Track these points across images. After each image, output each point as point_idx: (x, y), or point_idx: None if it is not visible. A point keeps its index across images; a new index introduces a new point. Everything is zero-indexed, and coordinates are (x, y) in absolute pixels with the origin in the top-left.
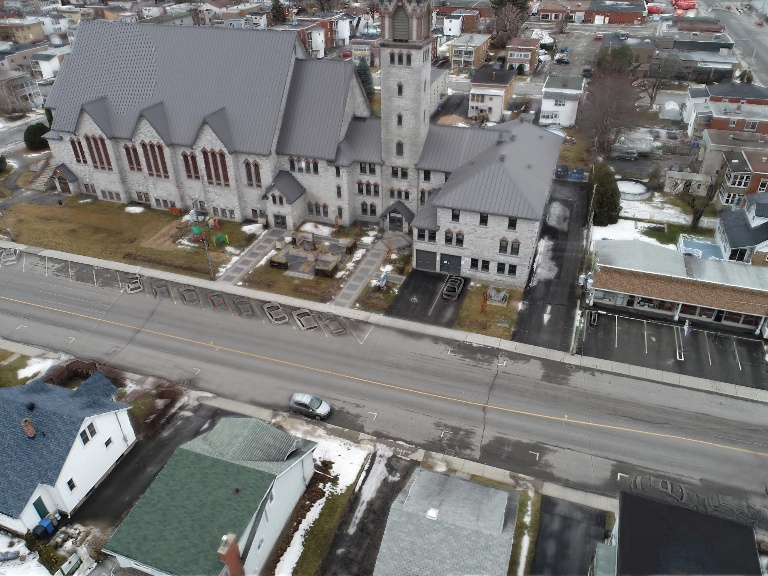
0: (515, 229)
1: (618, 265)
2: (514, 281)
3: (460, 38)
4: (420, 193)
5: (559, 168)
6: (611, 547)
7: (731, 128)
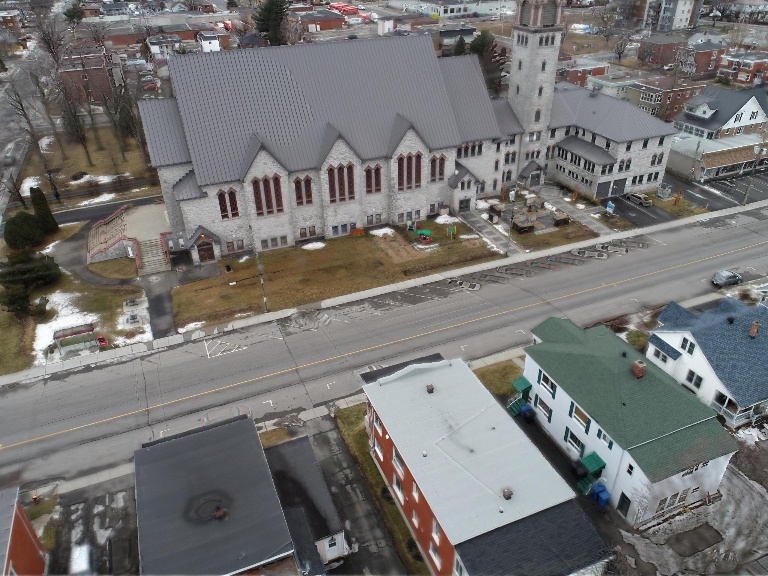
0: (662, 145)
1: None
2: (656, 184)
3: None
4: (546, 150)
5: None
6: None
7: (579, 76)
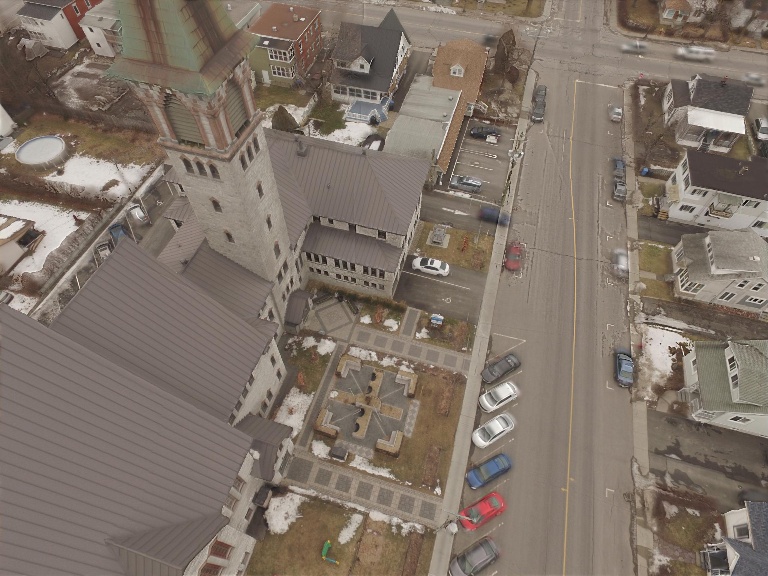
0: None
1: (430, 149)
2: None
3: None
4: None
5: None
6: (723, 196)
7: None
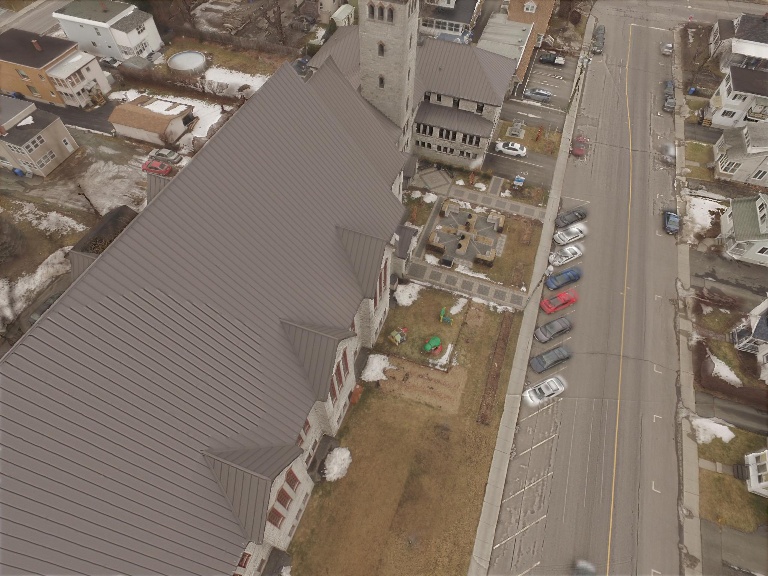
0: None
1: None
2: None
3: None
4: None
5: (302, 66)
6: (760, 99)
7: None
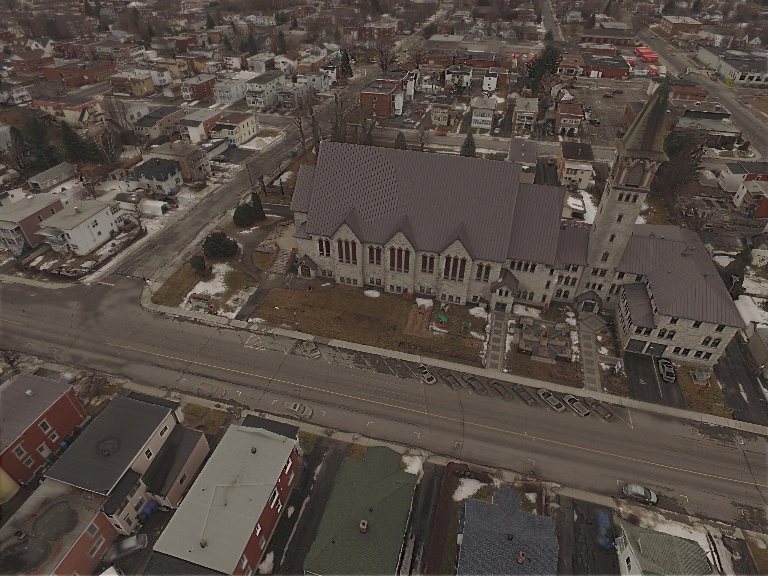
0: (721, 331)
1: None
2: (706, 362)
3: (518, 103)
4: (611, 286)
5: None
6: None
7: None
